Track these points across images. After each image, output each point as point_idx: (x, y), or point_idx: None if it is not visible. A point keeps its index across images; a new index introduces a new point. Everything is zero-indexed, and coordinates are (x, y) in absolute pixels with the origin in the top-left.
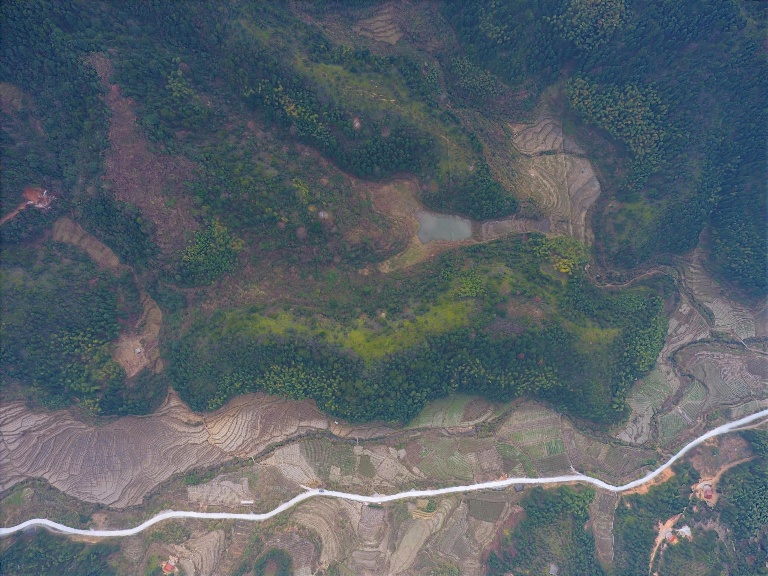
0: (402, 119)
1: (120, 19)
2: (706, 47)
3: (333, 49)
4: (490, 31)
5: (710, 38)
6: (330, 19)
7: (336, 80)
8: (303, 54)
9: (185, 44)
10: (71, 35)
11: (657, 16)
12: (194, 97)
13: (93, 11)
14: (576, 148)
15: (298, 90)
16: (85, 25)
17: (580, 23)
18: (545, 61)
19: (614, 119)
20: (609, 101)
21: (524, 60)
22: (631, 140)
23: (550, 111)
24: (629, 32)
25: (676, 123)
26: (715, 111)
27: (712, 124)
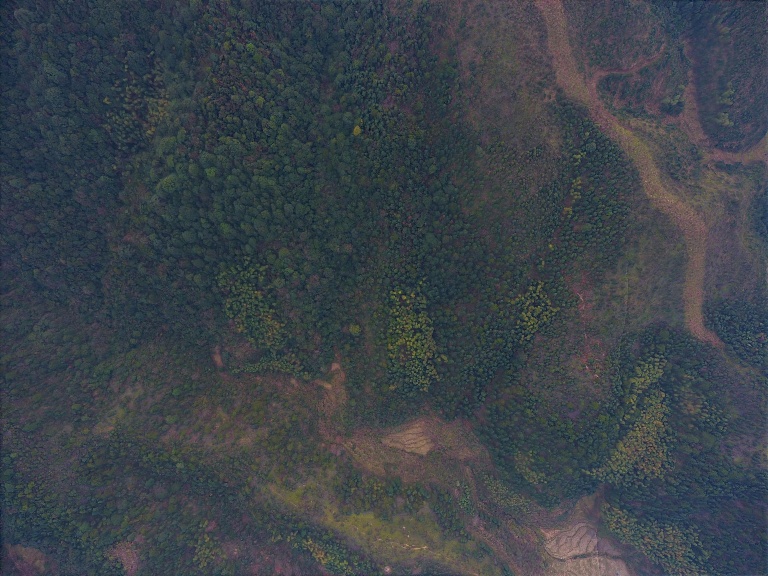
0: (434, 561)
1: (146, 488)
2: (752, 511)
3: (363, 486)
4: (526, 474)
5: (757, 504)
6: (360, 435)
7: (367, 534)
8: (333, 506)
9: (212, 490)
10: (97, 529)
11: (702, 482)
12: (221, 557)
13: (119, 496)
14: (611, 550)
15: (328, 542)
16: (111, 511)
17: (620, 468)
18: (582, 491)
19: (653, 548)
20: (648, 535)
21: (560, 492)
22: (670, 569)
23: (585, 517)
24: (671, 484)
25: (718, 568)
26: (760, 568)
27: (756, 574)
